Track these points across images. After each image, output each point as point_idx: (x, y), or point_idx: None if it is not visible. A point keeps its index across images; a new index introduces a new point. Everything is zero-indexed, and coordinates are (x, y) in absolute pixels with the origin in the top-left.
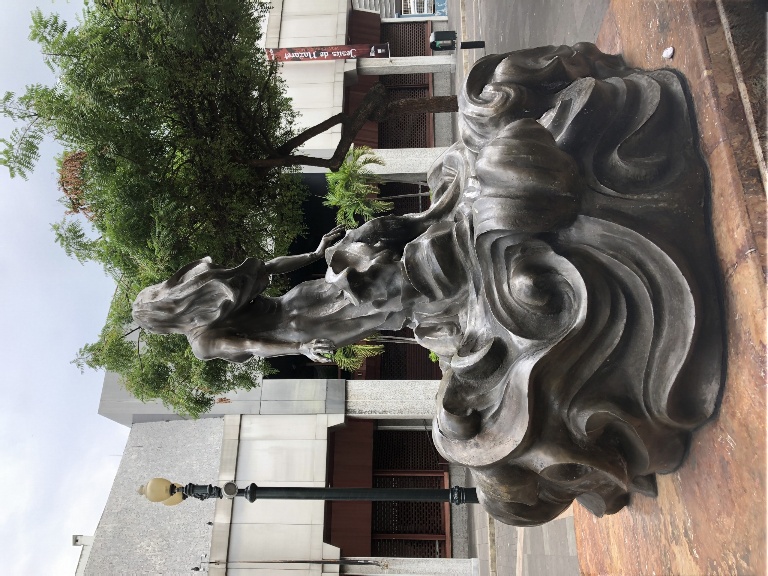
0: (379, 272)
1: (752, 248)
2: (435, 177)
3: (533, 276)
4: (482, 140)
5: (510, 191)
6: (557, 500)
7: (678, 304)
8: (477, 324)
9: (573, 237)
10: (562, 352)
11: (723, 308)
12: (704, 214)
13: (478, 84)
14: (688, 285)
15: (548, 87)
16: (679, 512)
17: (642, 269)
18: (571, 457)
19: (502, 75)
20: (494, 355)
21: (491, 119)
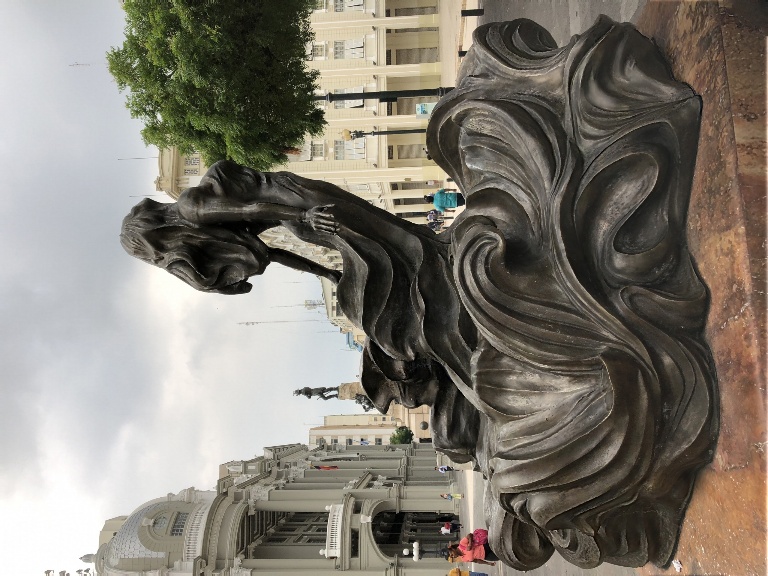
0: None
1: None
2: None
3: None
4: None
5: None
6: None
7: None
8: None
9: None
10: None
11: None
12: None
13: None
14: None
15: None
16: None
17: None
18: None
19: None
20: None
21: None
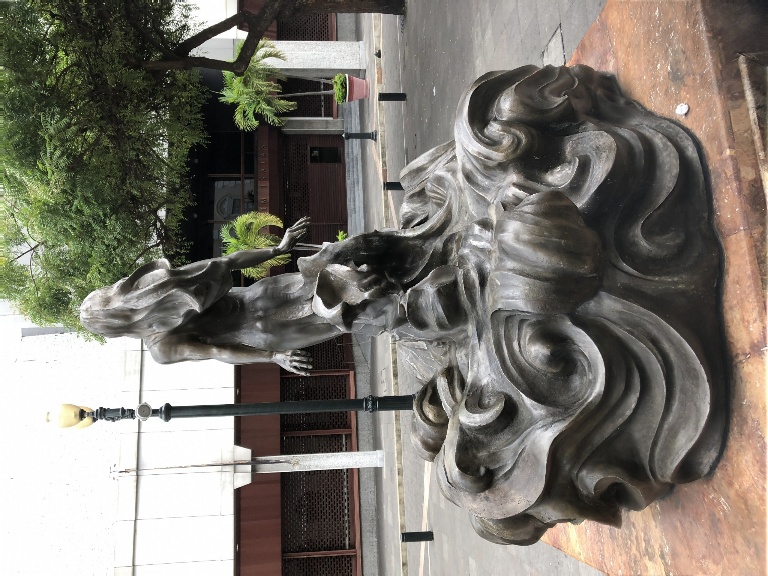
0: (370, 303)
1: None
2: (410, 178)
3: (550, 346)
4: (486, 180)
5: (538, 271)
6: (546, 526)
7: (692, 387)
8: (480, 372)
9: (591, 310)
10: (579, 425)
11: (729, 387)
12: (716, 294)
13: (479, 113)
14: (705, 374)
15: (556, 128)
16: (655, 535)
17: (657, 347)
18: (579, 513)
19: (510, 112)
20: (506, 415)
21: (500, 164)
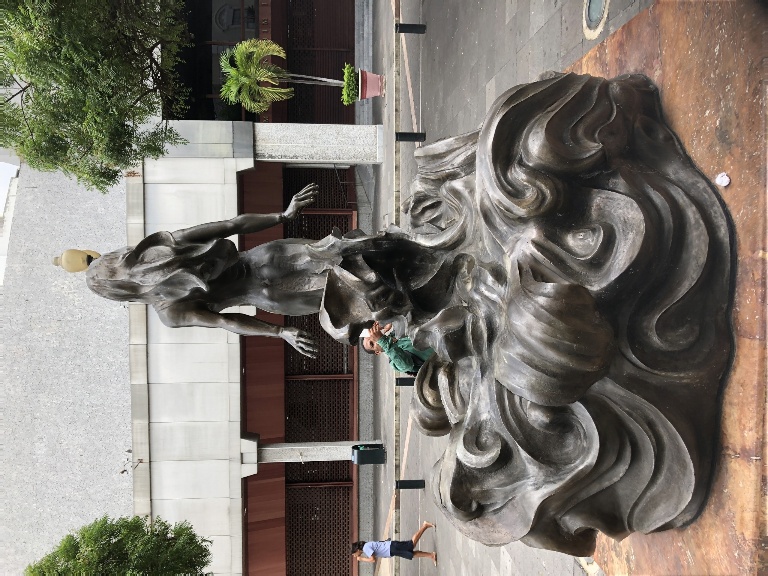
0: None
1: (758, 456)
2: (425, 160)
3: (550, 416)
4: (505, 226)
5: (546, 365)
6: None
7: (679, 472)
8: (480, 406)
9: (594, 388)
10: (568, 489)
11: (714, 470)
12: (719, 385)
13: (504, 146)
14: (693, 468)
15: (584, 177)
16: (625, 541)
17: (653, 430)
18: (558, 548)
19: (537, 159)
20: (501, 461)
21: (520, 218)
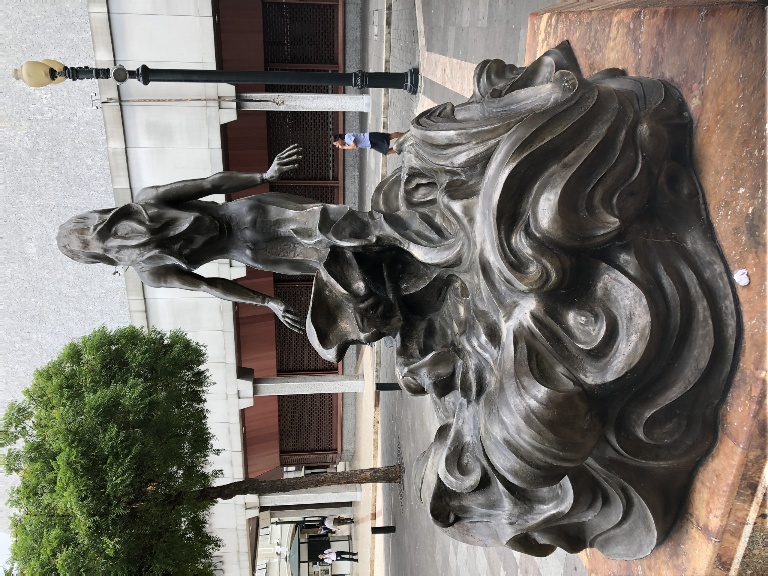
0: None
1: (718, 539)
2: (422, 141)
3: None
4: (504, 286)
5: (532, 457)
6: None
7: (643, 530)
8: (464, 429)
9: None
10: None
11: (675, 524)
12: (695, 465)
13: (511, 203)
14: (656, 534)
15: None
16: None
17: (625, 494)
18: (524, 551)
19: (546, 233)
20: (479, 488)
21: None
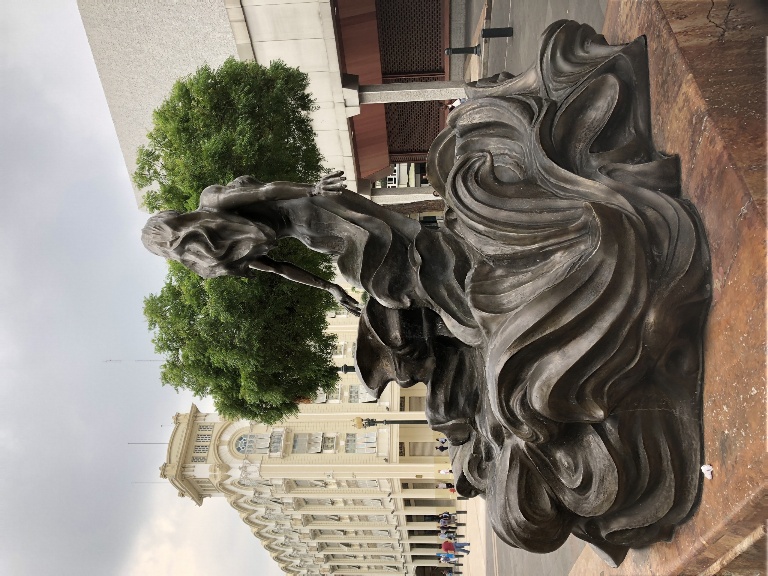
0: None
1: None
2: None
3: None
4: None
5: None
6: None
7: None
8: None
9: None
10: None
11: None
12: None
13: (512, 374)
14: None
15: None
16: None
17: None
18: None
19: None
20: None
21: None
